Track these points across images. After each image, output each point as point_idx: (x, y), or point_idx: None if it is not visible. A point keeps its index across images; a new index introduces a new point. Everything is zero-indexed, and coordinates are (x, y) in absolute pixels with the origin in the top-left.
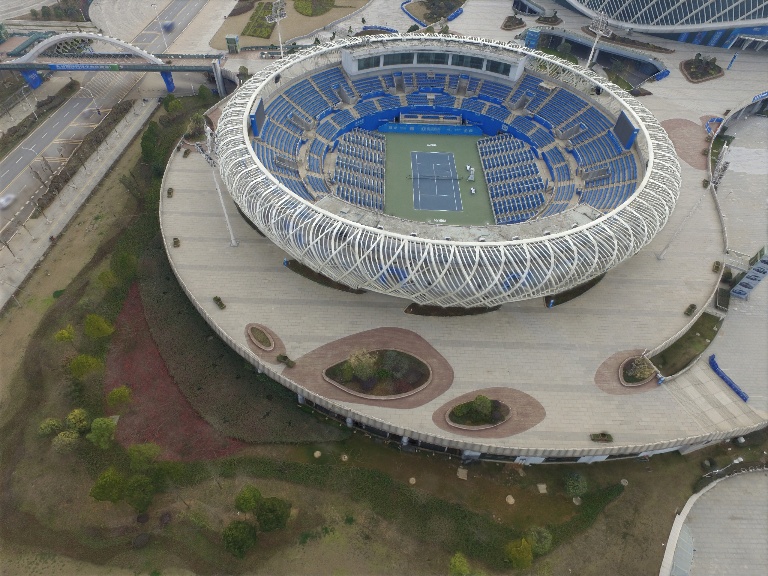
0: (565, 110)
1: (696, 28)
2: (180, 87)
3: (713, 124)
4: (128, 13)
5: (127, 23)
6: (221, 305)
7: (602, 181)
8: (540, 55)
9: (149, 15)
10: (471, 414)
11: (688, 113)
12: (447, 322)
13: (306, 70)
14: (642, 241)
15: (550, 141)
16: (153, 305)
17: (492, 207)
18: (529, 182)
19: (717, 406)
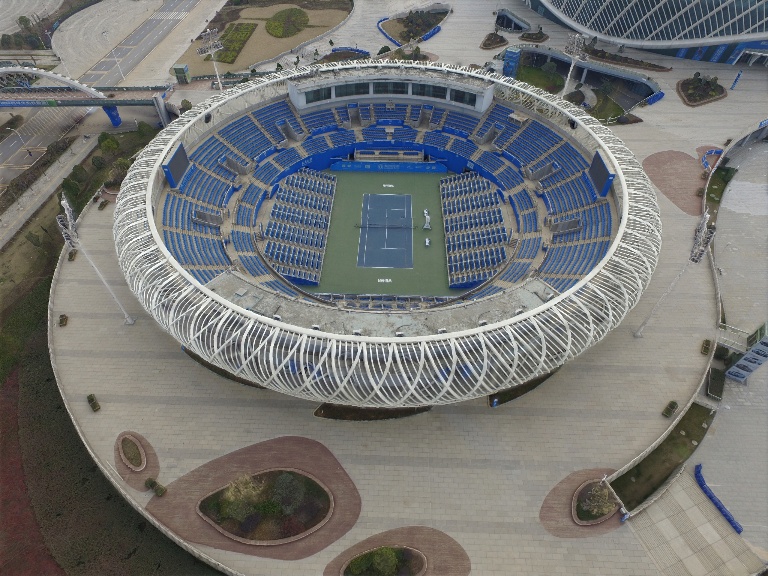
0: (537, 146)
1: (696, 43)
2: (127, 121)
3: (711, 157)
4: (92, 39)
5: (89, 50)
6: (94, 407)
7: (572, 235)
8: (509, 83)
9: (114, 40)
10: (371, 572)
11: (683, 144)
12: (364, 428)
13: (250, 104)
14: (606, 328)
15: (519, 182)
16: (30, 397)
17: (447, 263)
18: (491, 233)
19: (700, 548)
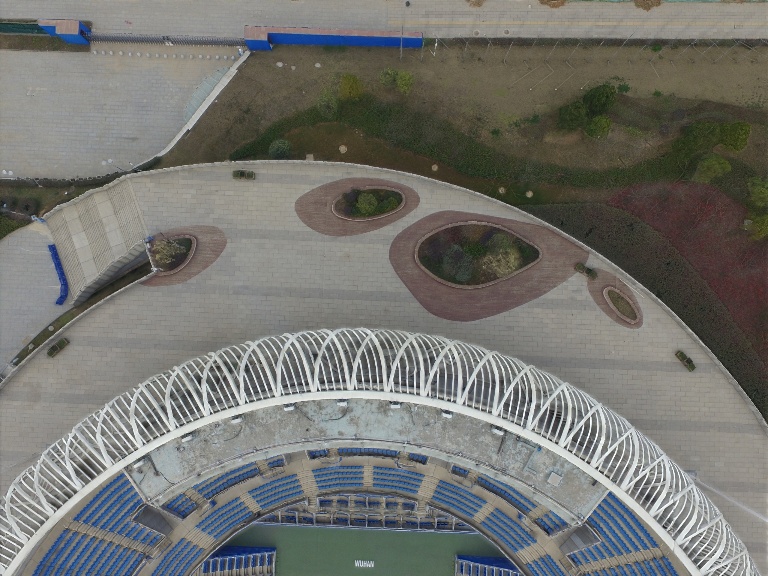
0: None
1: None
2: None
3: None
4: None
5: None
6: (683, 355)
7: None
8: None
9: None
10: (379, 198)
11: None
12: (388, 329)
13: None
14: None
15: None
16: (762, 385)
17: None
18: None
19: (95, 225)
